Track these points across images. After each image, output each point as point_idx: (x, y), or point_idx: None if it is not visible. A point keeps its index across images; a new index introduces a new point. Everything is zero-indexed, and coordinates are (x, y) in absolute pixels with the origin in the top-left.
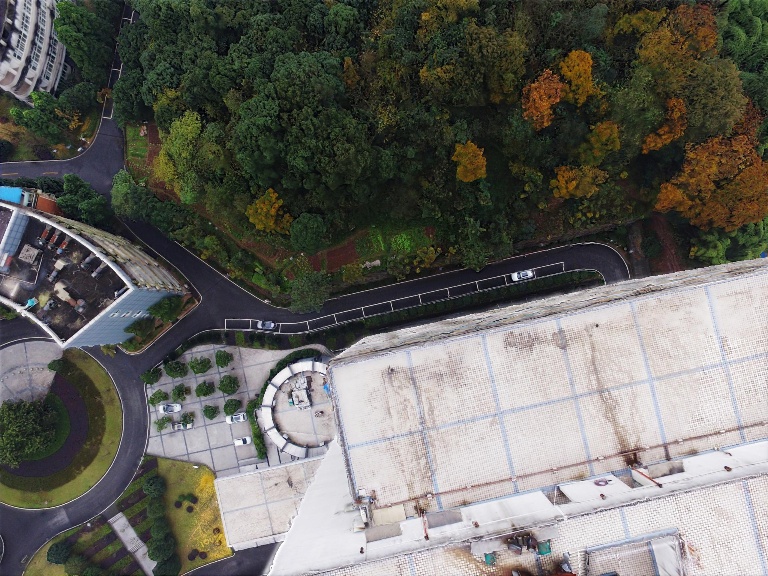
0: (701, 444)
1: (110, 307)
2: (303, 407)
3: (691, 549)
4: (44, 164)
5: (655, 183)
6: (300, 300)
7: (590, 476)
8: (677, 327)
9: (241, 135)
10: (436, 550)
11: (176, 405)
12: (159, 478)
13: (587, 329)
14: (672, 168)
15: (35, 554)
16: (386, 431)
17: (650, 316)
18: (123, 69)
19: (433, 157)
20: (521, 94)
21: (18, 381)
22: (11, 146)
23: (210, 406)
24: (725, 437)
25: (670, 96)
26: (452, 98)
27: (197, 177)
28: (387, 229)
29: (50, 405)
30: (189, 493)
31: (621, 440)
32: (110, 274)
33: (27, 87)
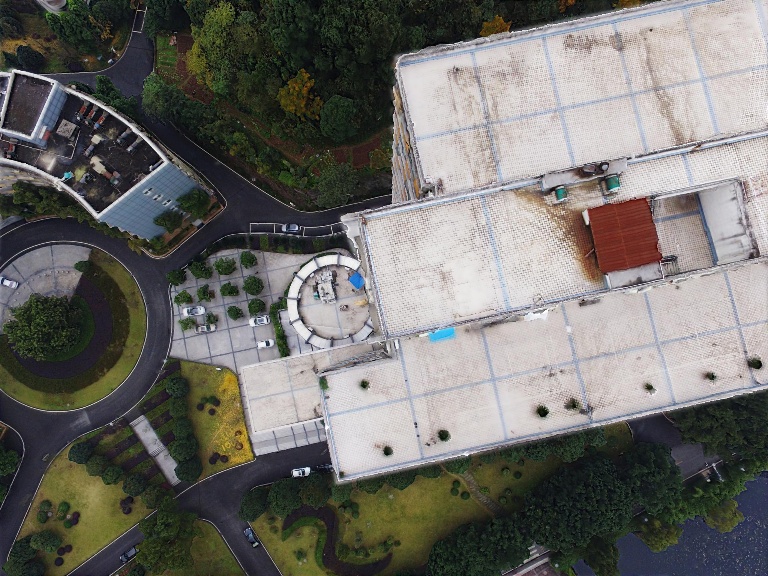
0: None
1: (145, 179)
2: (328, 300)
3: (754, 181)
4: (74, 76)
5: None
6: (327, 191)
7: None
8: (726, 31)
9: (277, 10)
10: (508, 196)
11: (200, 307)
12: (182, 379)
13: (641, 33)
14: None
15: (55, 457)
16: (452, 125)
17: (701, 21)
18: None
19: None
20: None
21: (44, 284)
22: (43, 58)
23: (234, 306)
24: None
25: None
26: None
27: (230, 64)
28: None
29: (75, 306)
30: (211, 396)
31: (676, 134)
32: (145, 150)
33: None
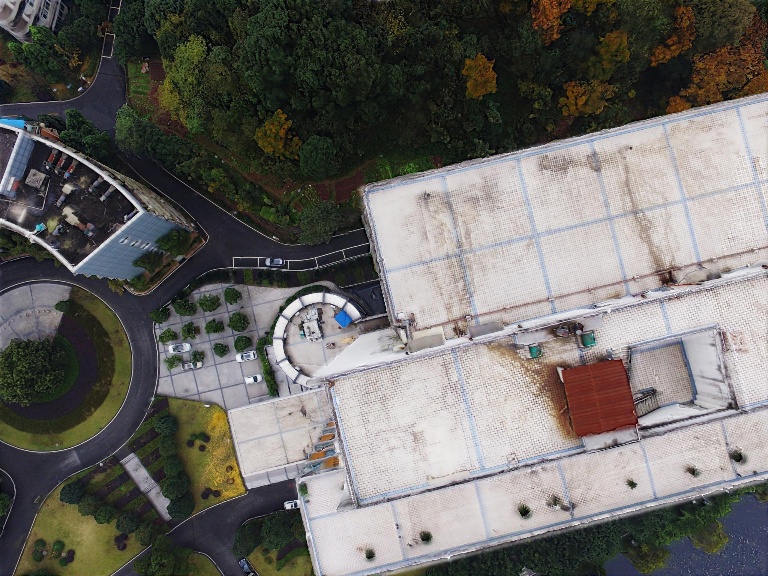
0: (734, 262)
1: (120, 230)
2: (314, 339)
3: (733, 335)
4: (44, 105)
5: (663, 102)
6: (310, 230)
7: (626, 295)
8: (710, 148)
9: (249, 51)
10: (481, 350)
11: (185, 344)
12: (170, 417)
13: (621, 151)
14: (679, 86)
15: (47, 497)
16: (424, 255)
17: (683, 138)
18: (122, 6)
19: (442, 77)
20: (531, 4)
21: (24, 324)
22: (9, 87)
23: (220, 343)
24: (758, 254)
25: (679, 3)
26: (462, 9)
27: (204, 102)
28: (395, 158)
29: (58, 347)
30: (201, 432)
31: (656, 260)
32: (119, 199)
33: (24, 24)
